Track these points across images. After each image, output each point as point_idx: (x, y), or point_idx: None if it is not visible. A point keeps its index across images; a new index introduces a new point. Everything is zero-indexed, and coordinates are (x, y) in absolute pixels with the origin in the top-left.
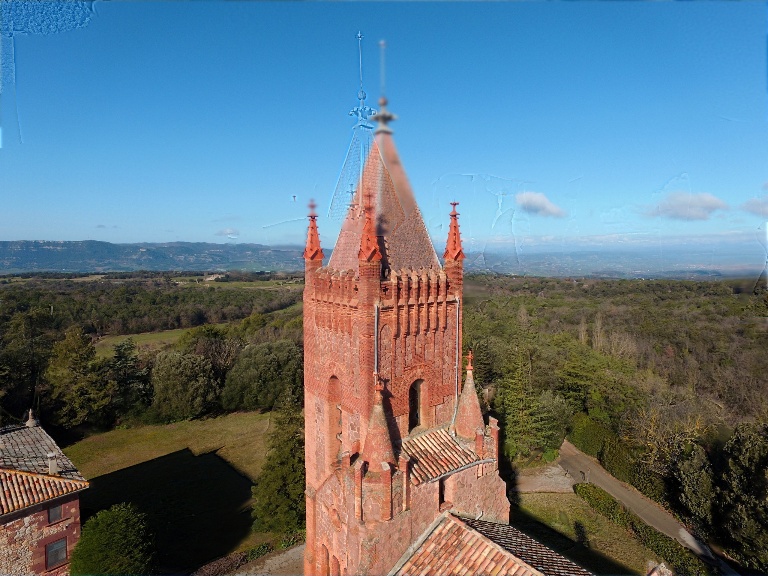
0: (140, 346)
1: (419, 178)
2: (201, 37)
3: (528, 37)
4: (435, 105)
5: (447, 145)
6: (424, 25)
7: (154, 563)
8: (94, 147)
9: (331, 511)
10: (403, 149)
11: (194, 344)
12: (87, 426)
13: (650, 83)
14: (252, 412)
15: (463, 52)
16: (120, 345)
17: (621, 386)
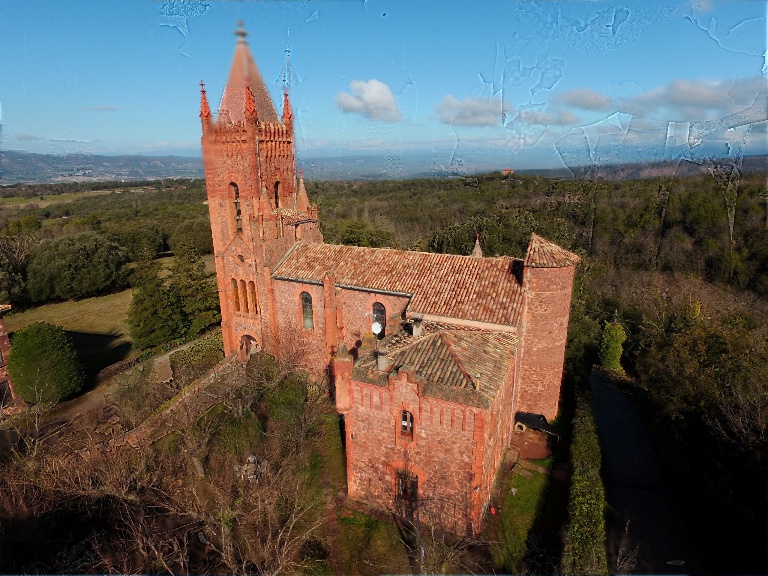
0: None
1: (303, 73)
2: (239, 22)
3: (332, 33)
4: (308, 51)
5: (311, 63)
6: (306, 28)
7: (77, 358)
8: None
9: (236, 257)
10: (299, 63)
11: None
12: None
13: (364, 51)
14: (64, 302)
15: (316, 36)
16: None
17: (380, 233)
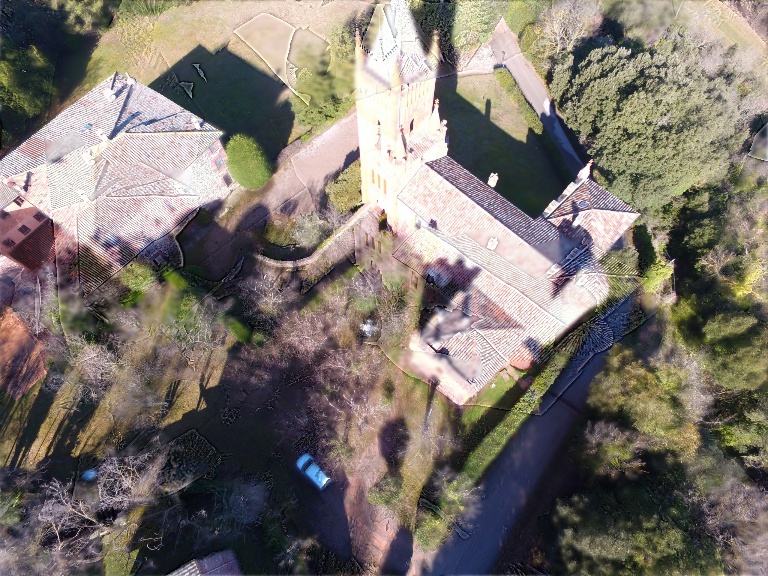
0: None
1: None
2: None
3: None
4: None
5: None
6: None
7: (265, 158)
8: None
9: None
10: None
11: None
12: (95, 27)
13: None
14: None
15: None
16: None
17: None
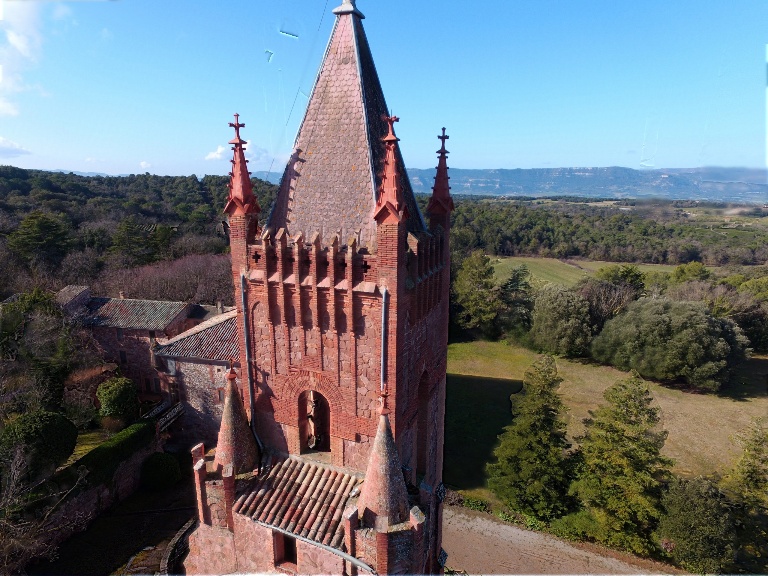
0: (533, 274)
1: None
2: None
3: None
4: None
5: None
6: None
7: None
8: None
9: None
10: None
11: (584, 283)
12: (479, 332)
13: None
14: None
15: None
16: (517, 270)
17: None
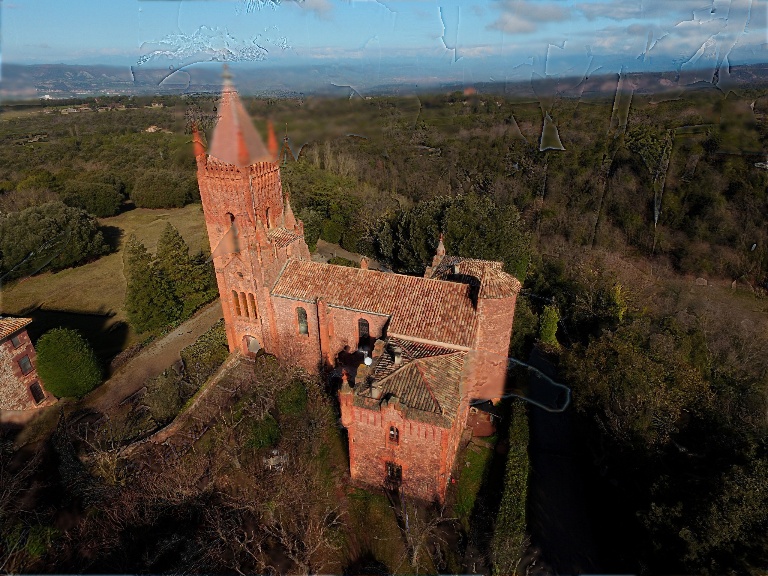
0: None
1: None
2: None
3: None
4: None
5: None
6: None
7: (94, 355)
8: None
9: (236, 274)
10: None
11: None
12: None
13: None
14: (42, 274)
15: (308, 123)
16: None
17: (348, 197)
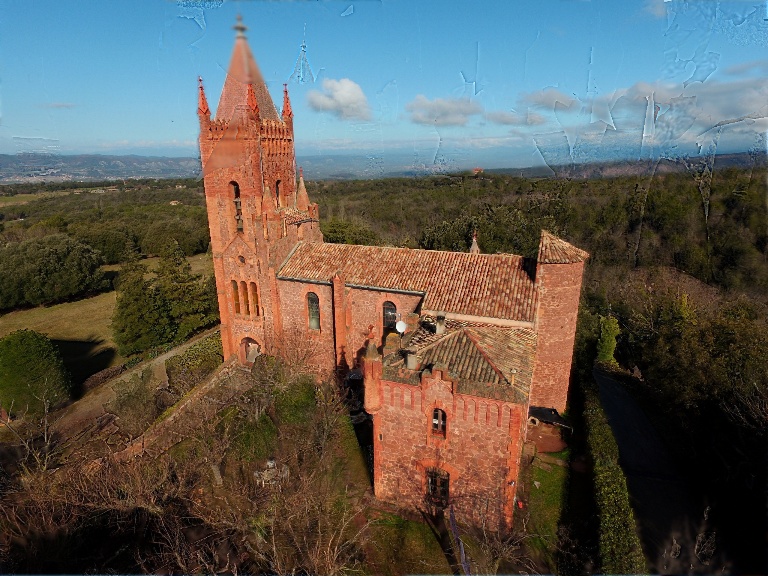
0: None
1: (318, 69)
2: (255, 15)
3: (347, 29)
4: (323, 46)
5: (325, 59)
6: (322, 23)
7: None
8: (210, 47)
9: (237, 258)
10: (313, 59)
11: None
12: None
13: (377, 47)
14: (34, 308)
15: (331, 31)
16: None
17: (364, 232)
